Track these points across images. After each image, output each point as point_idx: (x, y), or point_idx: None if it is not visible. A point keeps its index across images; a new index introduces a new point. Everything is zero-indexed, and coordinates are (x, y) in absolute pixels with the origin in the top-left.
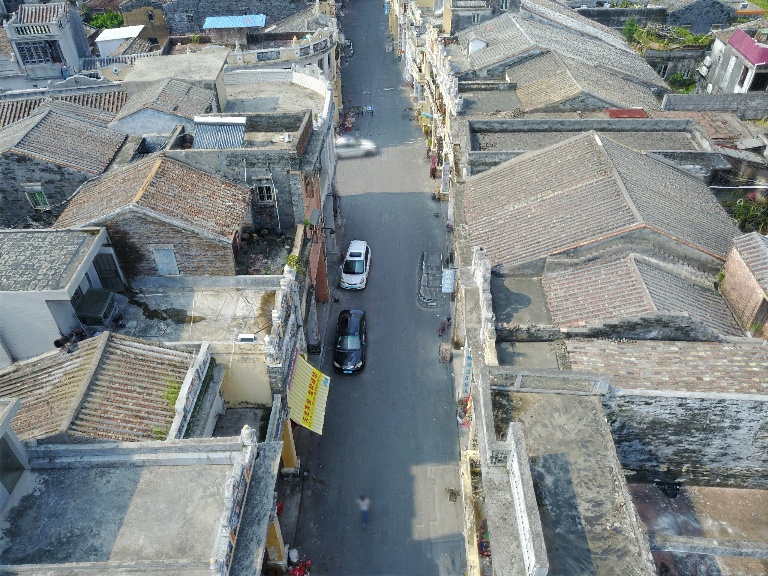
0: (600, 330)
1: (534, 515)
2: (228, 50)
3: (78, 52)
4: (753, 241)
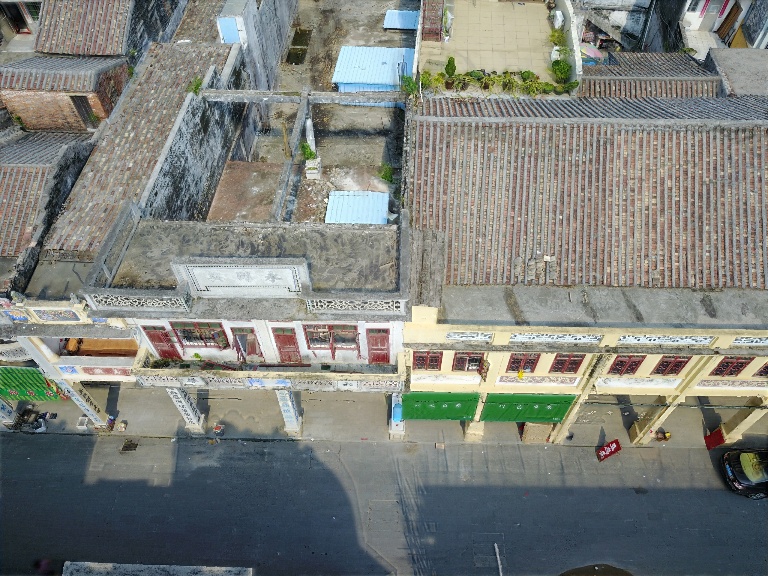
0: (47, 216)
1: (264, 260)
2: None
3: None
4: (4, 73)
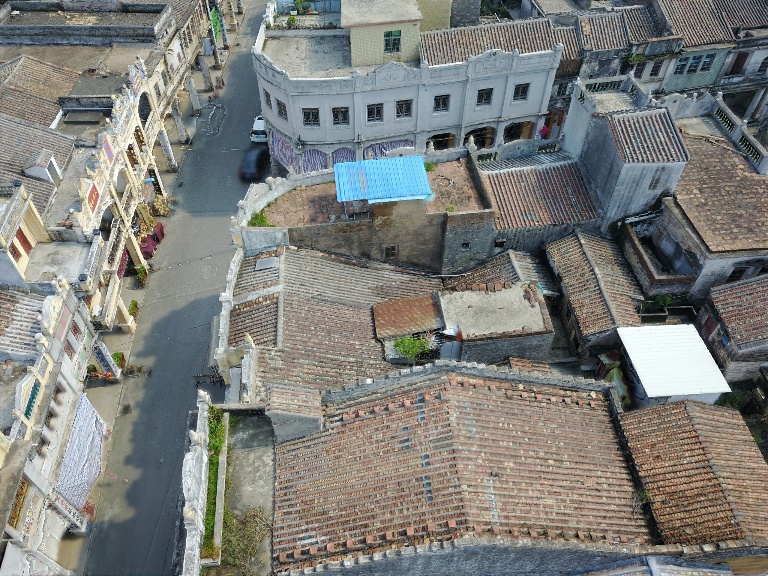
0: None
1: None
2: (383, 158)
3: (586, 157)
4: None
